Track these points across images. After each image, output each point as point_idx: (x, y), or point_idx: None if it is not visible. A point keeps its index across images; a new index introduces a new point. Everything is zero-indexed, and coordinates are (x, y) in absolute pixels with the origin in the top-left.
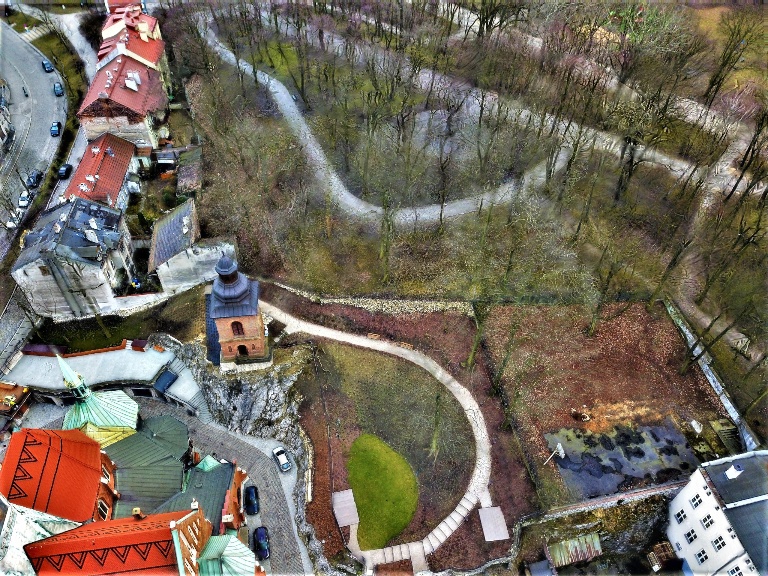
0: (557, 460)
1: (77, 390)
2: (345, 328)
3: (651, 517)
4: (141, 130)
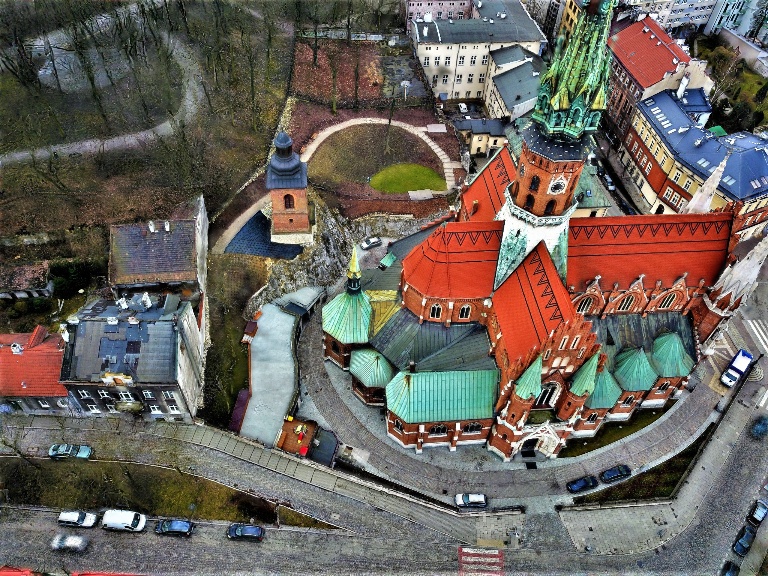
0: (403, 96)
1: None
2: None
3: None
4: None
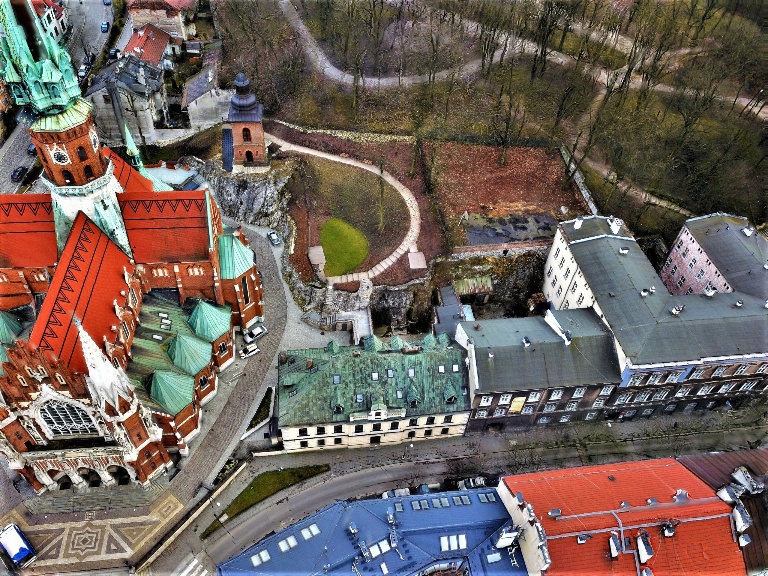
0: (466, 228)
1: (135, 158)
2: (324, 149)
3: (527, 267)
4: (176, 23)
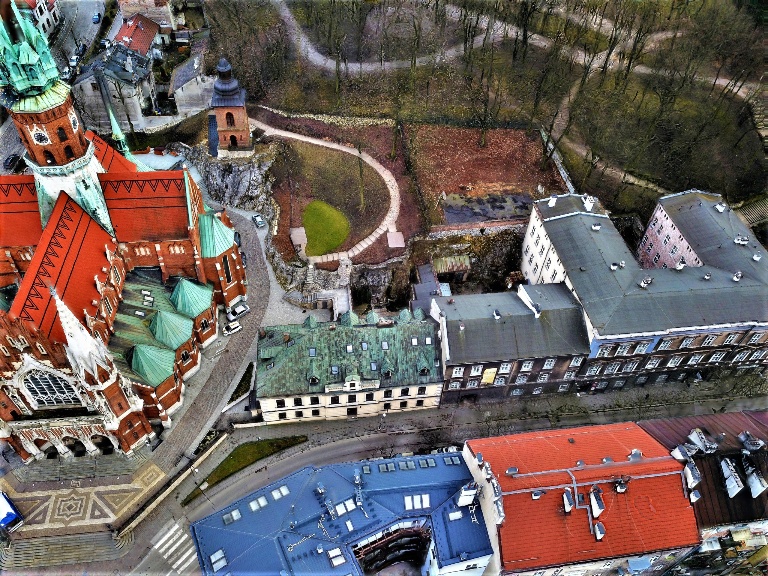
0: (444, 208)
1: (120, 143)
2: (307, 134)
3: (505, 245)
4: (164, 12)
